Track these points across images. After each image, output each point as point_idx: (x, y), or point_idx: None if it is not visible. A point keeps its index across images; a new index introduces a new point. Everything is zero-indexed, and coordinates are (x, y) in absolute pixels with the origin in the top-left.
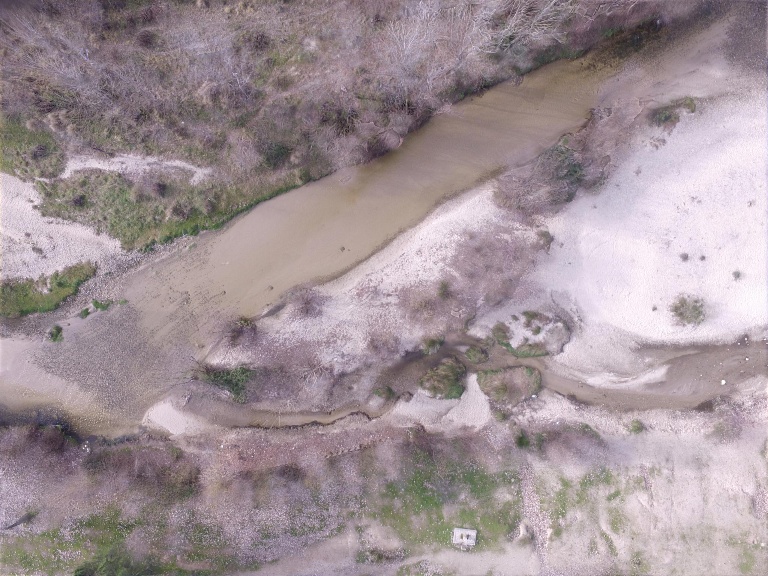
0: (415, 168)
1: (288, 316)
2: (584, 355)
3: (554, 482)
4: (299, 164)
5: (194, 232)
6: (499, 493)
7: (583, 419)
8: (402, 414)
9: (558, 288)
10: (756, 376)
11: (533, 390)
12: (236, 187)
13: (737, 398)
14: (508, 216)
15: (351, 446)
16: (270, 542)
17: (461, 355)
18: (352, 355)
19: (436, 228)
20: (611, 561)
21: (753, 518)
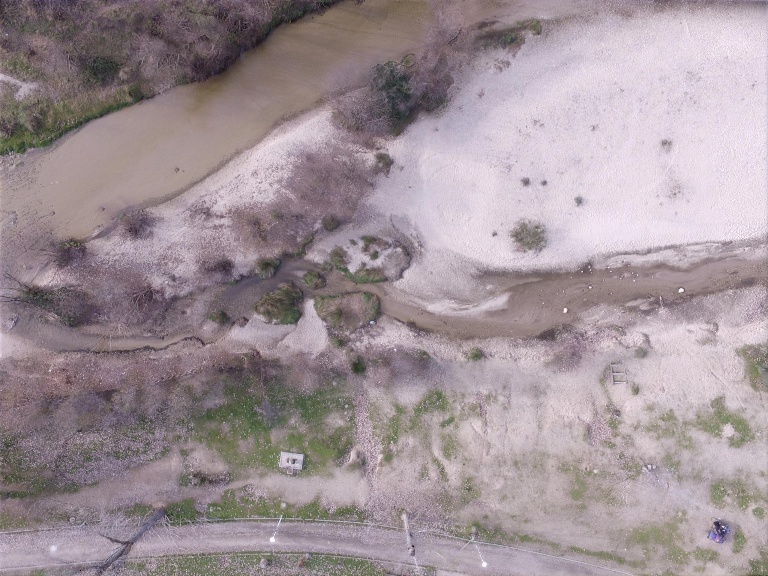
0: (253, 87)
1: (119, 238)
2: (424, 281)
3: (388, 408)
4: (129, 80)
5: (21, 149)
6: (331, 419)
7: (421, 346)
8: (237, 339)
9: (398, 212)
10: (599, 304)
11: (371, 316)
12: (63, 103)
13: (579, 327)
14: (348, 138)
15: (183, 371)
16: (91, 465)
17: (298, 280)
18: (184, 278)
19: (273, 149)
20: (441, 487)
21: (587, 445)
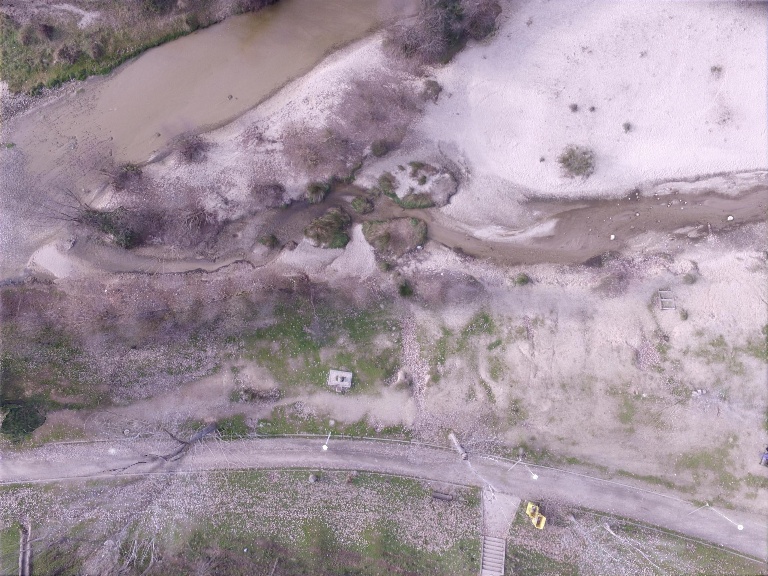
0: (304, 17)
1: (174, 162)
2: (471, 207)
3: (435, 331)
4: (186, 9)
5: (82, 77)
6: (379, 340)
7: (468, 271)
8: (286, 263)
9: (445, 139)
10: (646, 232)
11: (418, 241)
12: (123, 31)
13: (627, 254)
14: (397, 66)
15: (234, 293)
16: (146, 380)
17: (347, 205)
18: (236, 201)
19: (323, 76)
20: (489, 408)
21: (635, 369)
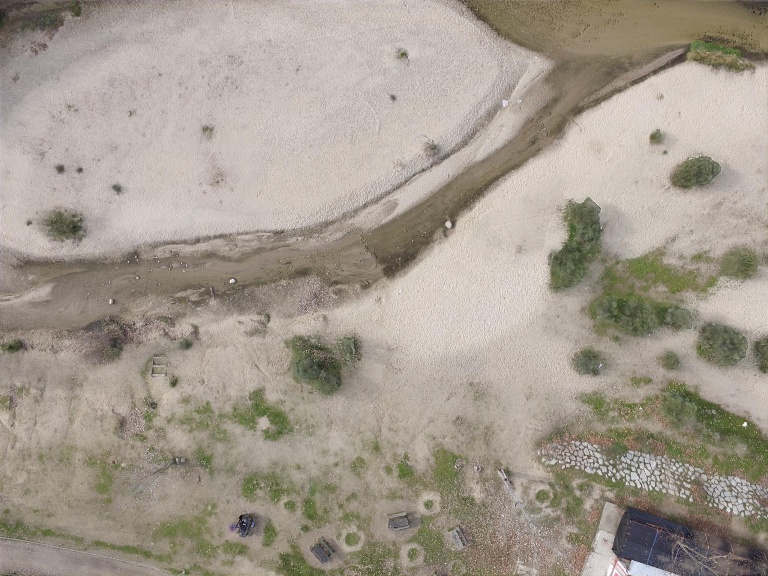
0: None
1: None
2: None
3: None
4: None
5: None
6: None
7: None
8: None
9: None
10: (147, 295)
11: None
12: None
13: (127, 318)
14: None
15: None
16: None
17: None
18: None
19: None
20: None
21: (117, 438)
